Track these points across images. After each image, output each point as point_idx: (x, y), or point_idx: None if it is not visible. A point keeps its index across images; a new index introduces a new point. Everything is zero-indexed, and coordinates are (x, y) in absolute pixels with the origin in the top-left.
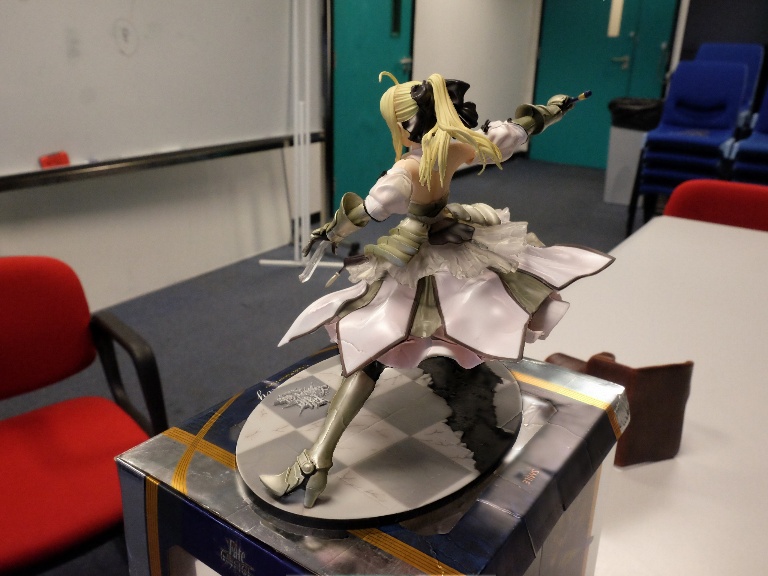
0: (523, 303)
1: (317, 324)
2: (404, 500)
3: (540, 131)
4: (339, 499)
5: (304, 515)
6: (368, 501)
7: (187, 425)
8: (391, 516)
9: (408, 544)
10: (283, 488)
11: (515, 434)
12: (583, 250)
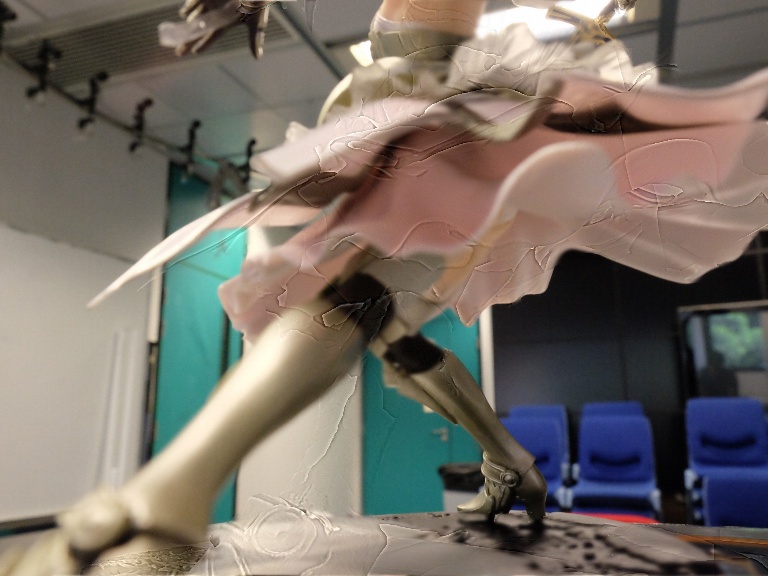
0: None
1: None
2: None
3: None
4: None
5: None
6: None
7: None
8: None
9: None
10: None
11: None
12: None
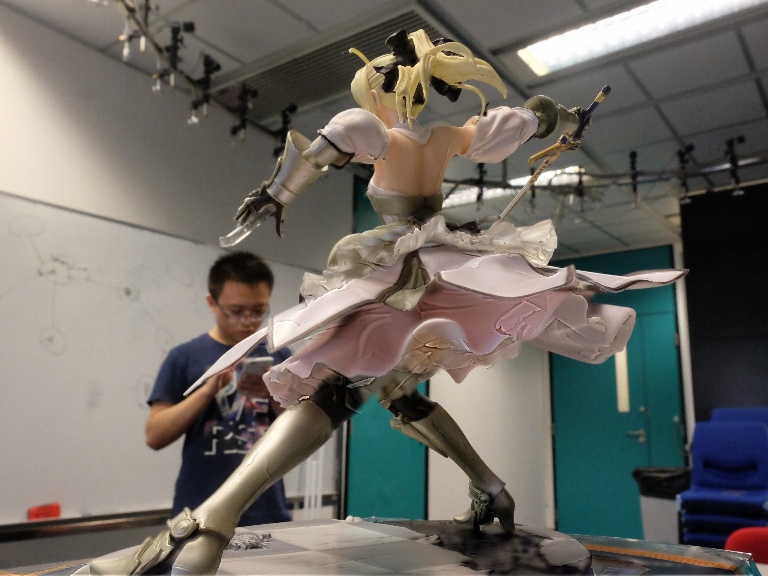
0: None
1: (247, 349)
2: None
3: (554, 127)
4: None
5: None
6: None
7: None
8: None
9: None
10: (126, 570)
11: (585, 572)
12: (639, 275)
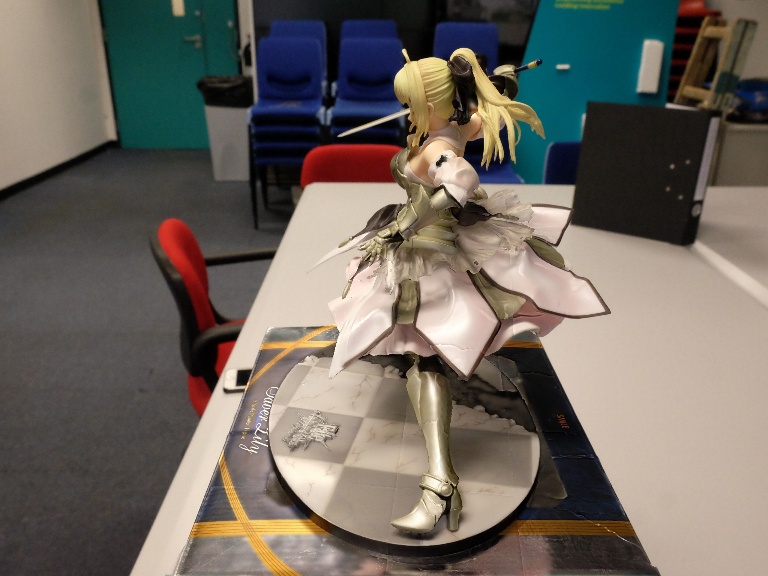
0: (554, 264)
1: (373, 339)
2: (516, 483)
3: None
4: (468, 509)
5: (461, 539)
6: (492, 499)
7: (209, 514)
8: (523, 502)
9: (555, 519)
10: (431, 522)
11: None
12: (542, 208)
